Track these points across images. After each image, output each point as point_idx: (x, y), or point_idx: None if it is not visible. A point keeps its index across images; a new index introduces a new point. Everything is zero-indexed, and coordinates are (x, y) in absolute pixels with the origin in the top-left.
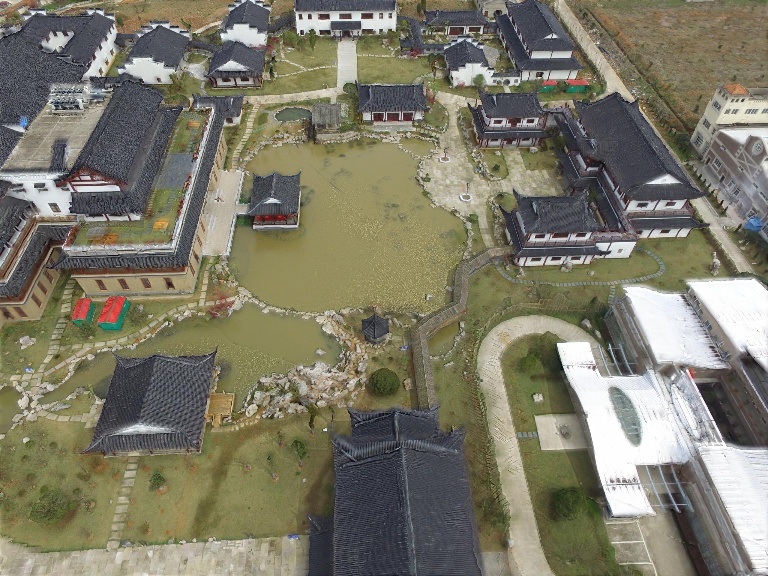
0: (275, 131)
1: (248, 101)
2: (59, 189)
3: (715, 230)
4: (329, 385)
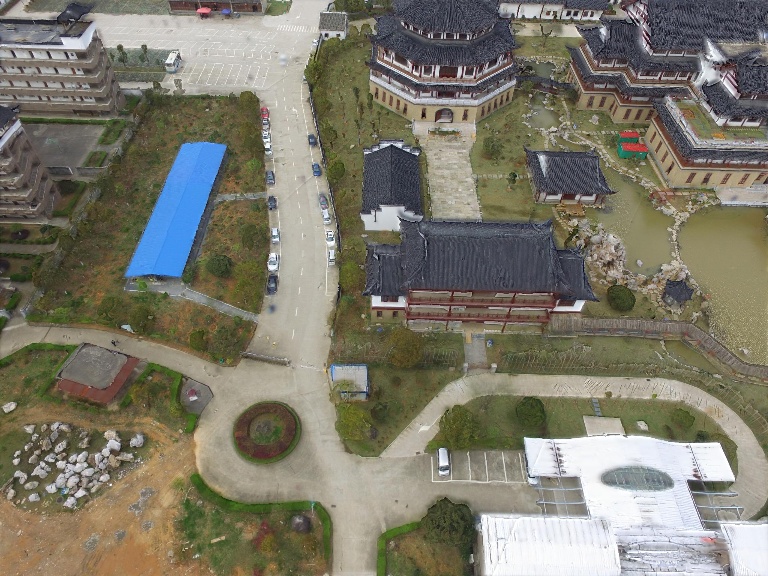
0: None
1: None
2: (720, 74)
3: None
4: (606, 259)
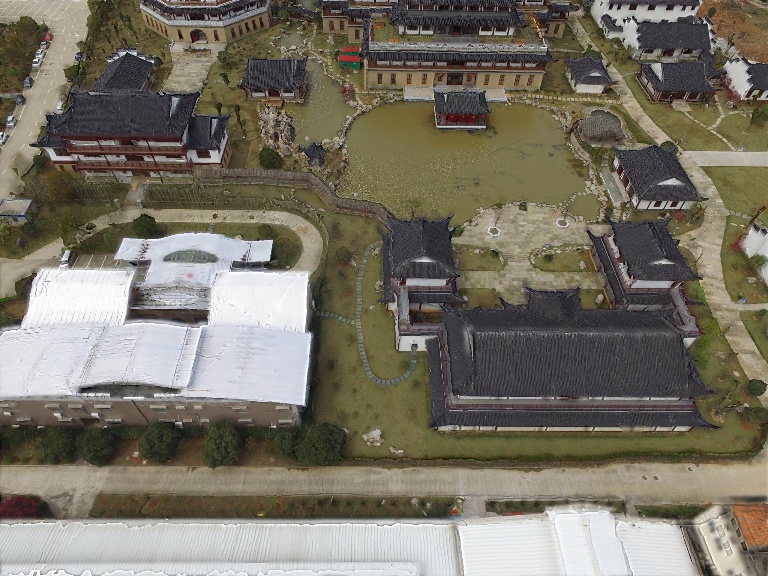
0: (574, 111)
1: (624, 97)
2: None
3: (456, 482)
4: None
